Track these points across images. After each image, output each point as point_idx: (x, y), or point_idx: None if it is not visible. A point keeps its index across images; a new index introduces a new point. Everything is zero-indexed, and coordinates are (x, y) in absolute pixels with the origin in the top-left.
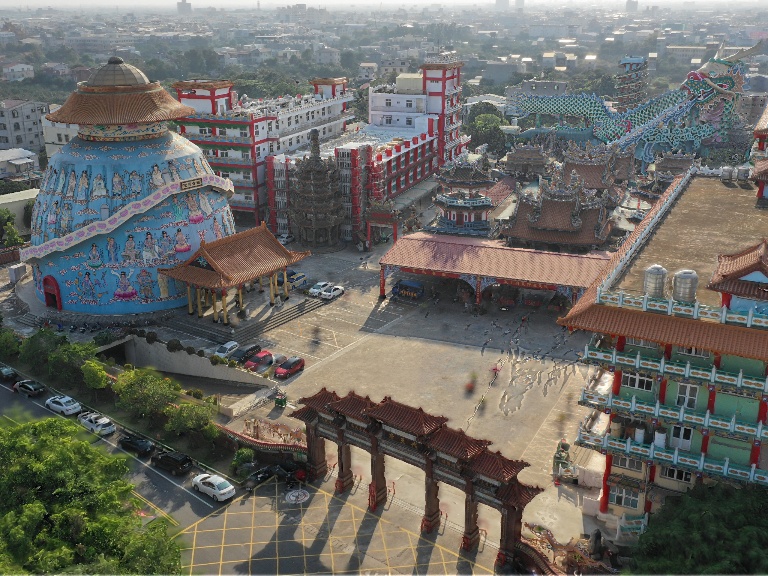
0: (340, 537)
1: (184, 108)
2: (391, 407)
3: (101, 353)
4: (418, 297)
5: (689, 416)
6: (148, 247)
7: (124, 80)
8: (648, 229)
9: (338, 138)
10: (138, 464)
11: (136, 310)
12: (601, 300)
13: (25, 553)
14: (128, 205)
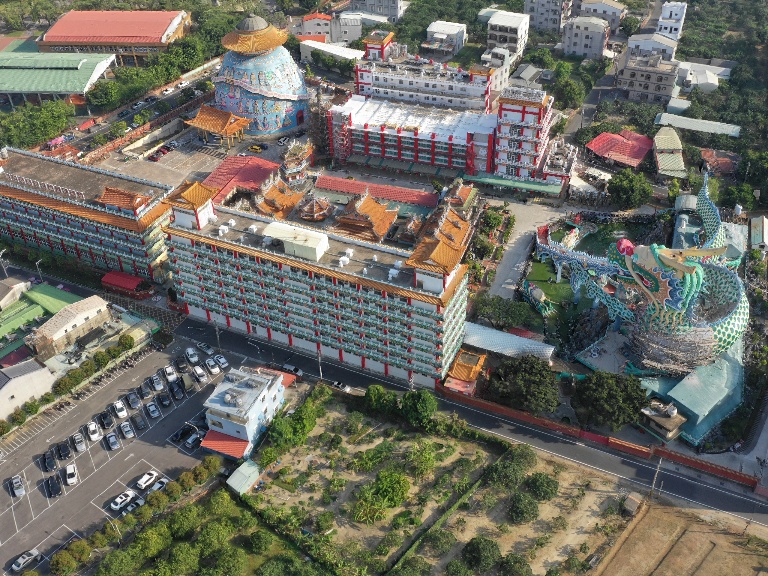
0: None
1: (254, 48)
2: None
3: None
4: None
5: None
6: None
7: None
8: (70, 163)
9: None
10: None
11: None
12: None
13: None
14: None
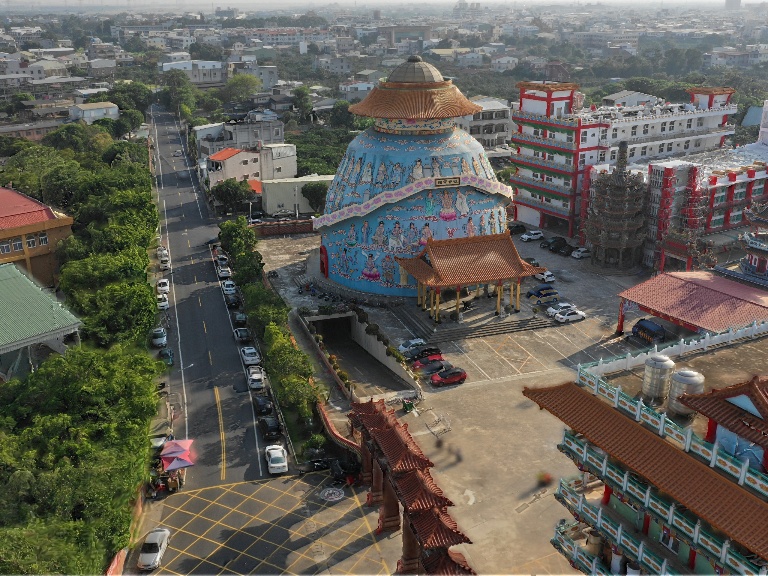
0: (326, 544)
1: (467, 108)
2: (392, 434)
3: (324, 321)
4: (654, 342)
5: (647, 557)
6: (395, 235)
7: (413, 77)
8: None
9: (694, 154)
10: (250, 420)
11: (378, 291)
12: (580, 380)
13: (43, 450)
14: (382, 193)
